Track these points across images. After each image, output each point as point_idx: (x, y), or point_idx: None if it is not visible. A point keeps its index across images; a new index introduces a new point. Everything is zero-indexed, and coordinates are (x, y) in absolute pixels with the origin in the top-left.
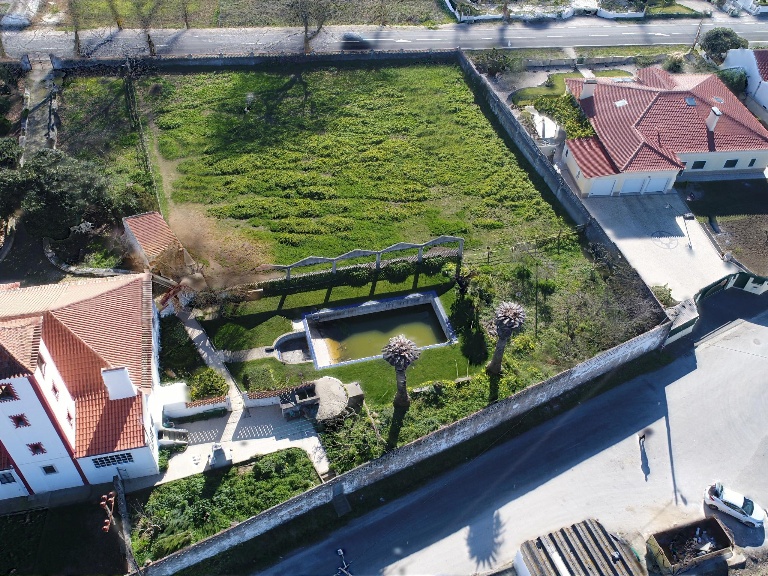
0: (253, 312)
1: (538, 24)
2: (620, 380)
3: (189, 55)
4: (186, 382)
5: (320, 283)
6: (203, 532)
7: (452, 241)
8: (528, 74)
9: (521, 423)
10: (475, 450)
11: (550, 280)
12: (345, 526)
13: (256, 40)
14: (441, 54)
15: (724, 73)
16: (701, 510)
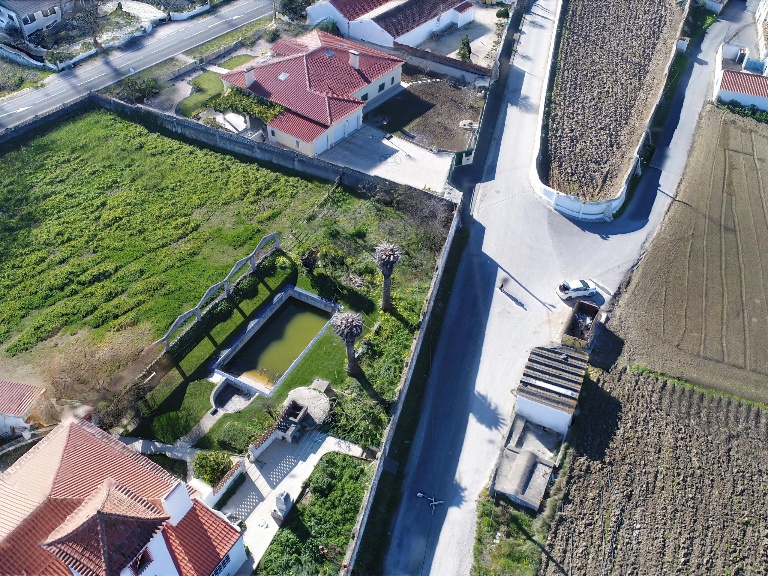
0: (166, 395)
1: (133, 46)
2: (456, 263)
3: None
4: (194, 477)
5: (195, 336)
6: (331, 562)
7: None
8: (170, 89)
9: (433, 329)
10: (426, 367)
11: (356, 227)
12: (405, 478)
13: None
14: (76, 105)
15: (321, 26)
16: (565, 305)
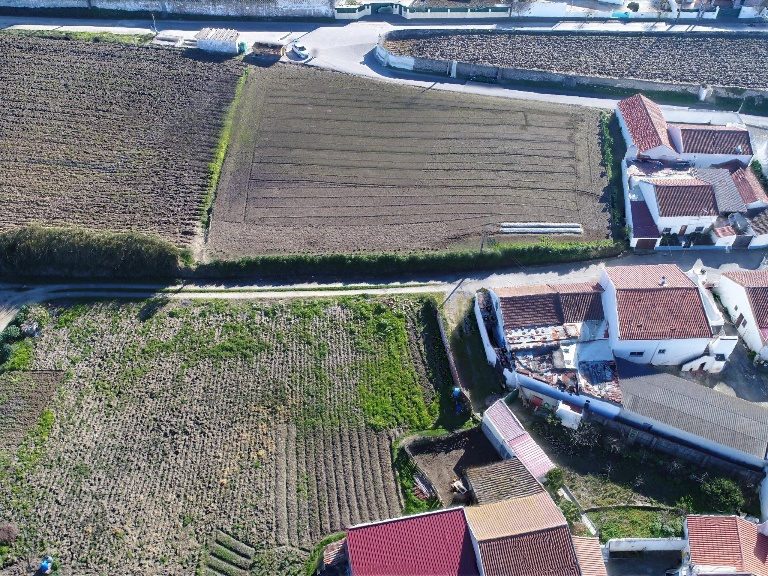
0: None
1: None
2: (306, 21)
3: None
4: None
5: None
6: None
7: None
8: None
9: (250, 18)
10: (226, 20)
11: None
12: (162, 20)
13: None
14: None
15: None
16: None
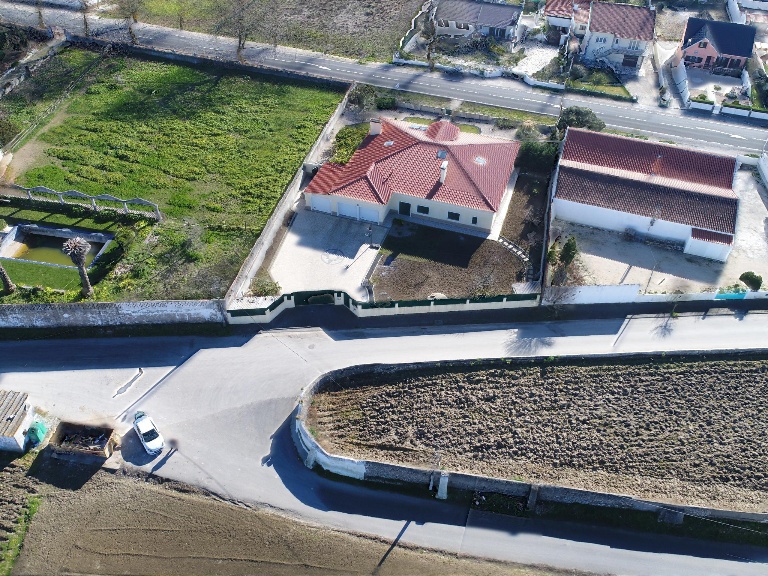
0: None
1: (455, 77)
2: (175, 333)
3: (152, 47)
4: None
5: (50, 208)
6: None
7: (147, 204)
8: (391, 113)
9: (73, 332)
10: (28, 336)
11: (199, 253)
12: None
13: (218, 46)
14: (339, 83)
15: (534, 144)
16: (128, 429)
